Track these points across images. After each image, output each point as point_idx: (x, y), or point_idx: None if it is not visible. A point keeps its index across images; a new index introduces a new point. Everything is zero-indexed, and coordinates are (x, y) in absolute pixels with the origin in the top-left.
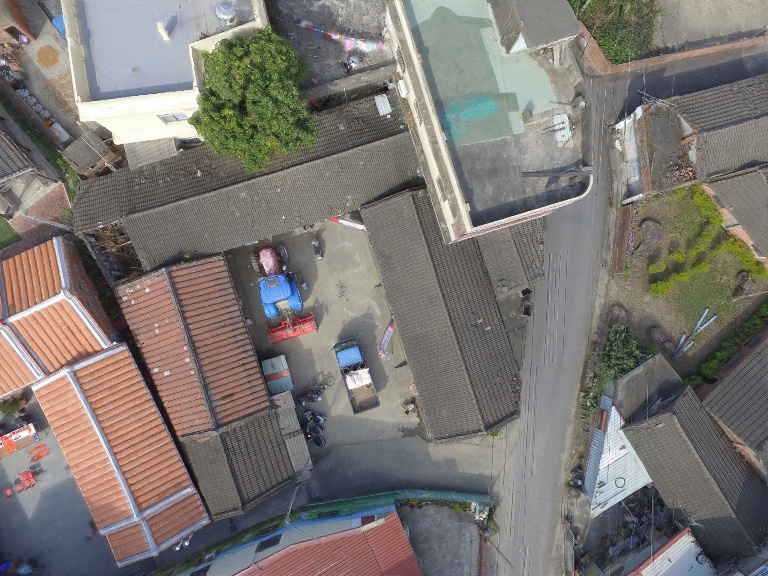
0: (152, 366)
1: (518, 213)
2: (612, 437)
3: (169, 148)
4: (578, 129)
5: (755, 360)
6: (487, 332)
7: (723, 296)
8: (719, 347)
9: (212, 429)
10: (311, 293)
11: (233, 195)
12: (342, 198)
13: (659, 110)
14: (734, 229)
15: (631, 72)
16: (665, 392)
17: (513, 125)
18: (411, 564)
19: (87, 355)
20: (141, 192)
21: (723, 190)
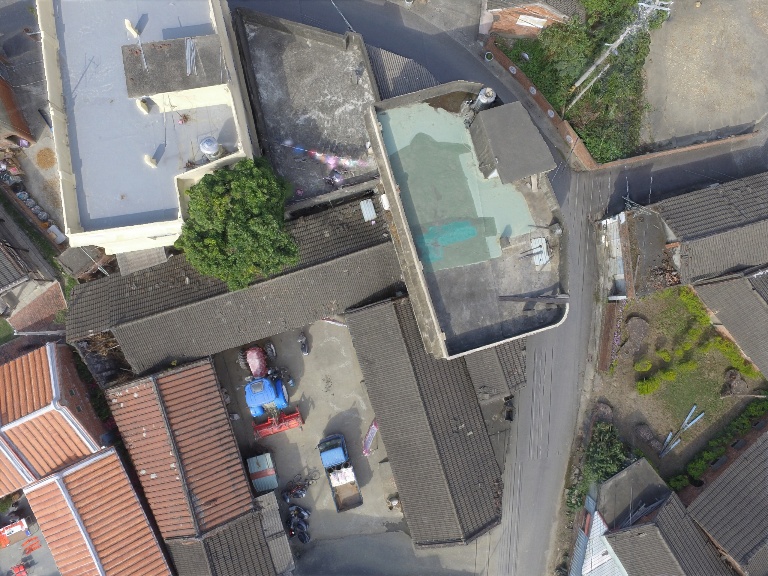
0: (139, 468)
1: (495, 337)
2: (595, 542)
3: (159, 256)
4: (556, 252)
5: (741, 465)
6: (469, 437)
7: (711, 393)
8: (706, 445)
9: (195, 536)
10: (298, 388)
11: (220, 304)
12: (327, 303)
13: None
14: (721, 327)
15: (618, 167)
16: (649, 497)
17: (491, 249)
18: None
19: (76, 459)
20: (131, 300)
21: (708, 294)
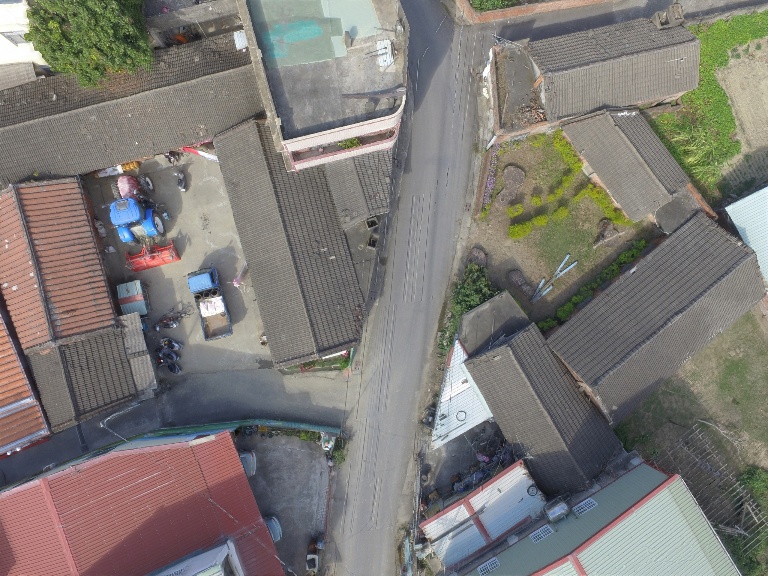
0: (2, 281)
1: None
2: (454, 370)
3: (28, 73)
4: (401, 55)
5: (603, 301)
6: (331, 261)
7: (585, 243)
8: (577, 292)
9: (49, 340)
10: (175, 225)
11: (84, 118)
12: (195, 127)
13: (514, 54)
14: (594, 176)
15: (501, 22)
16: (510, 329)
17: (336, 48)
18: (239, 481)
19: None
20: None
21: (575, 133)
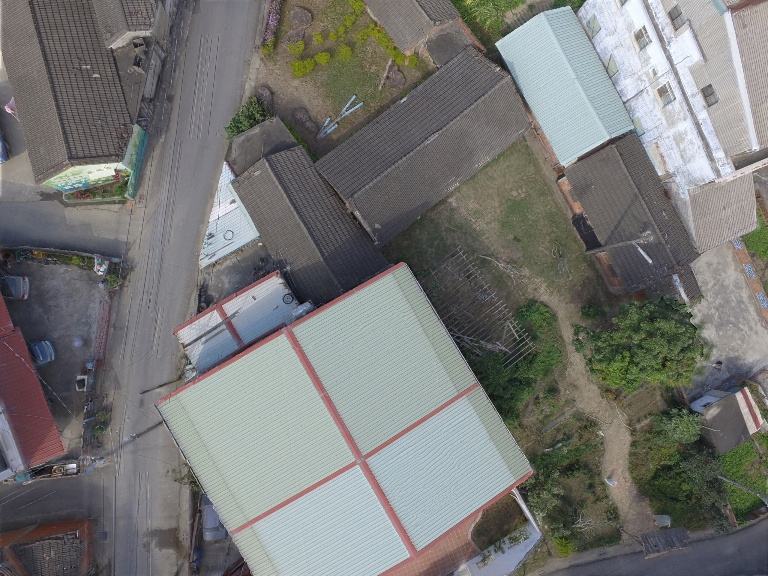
0: None
1: None
2: (222, 191)
3: None
4: None
5: (372, 128)
6: (94, 79)
7: (371, 84)
8: None
9: None
10: None
11: None
12: None
13: None
14: None
15: None
16: None
17: None
18: None
19: None
20: None
21: None
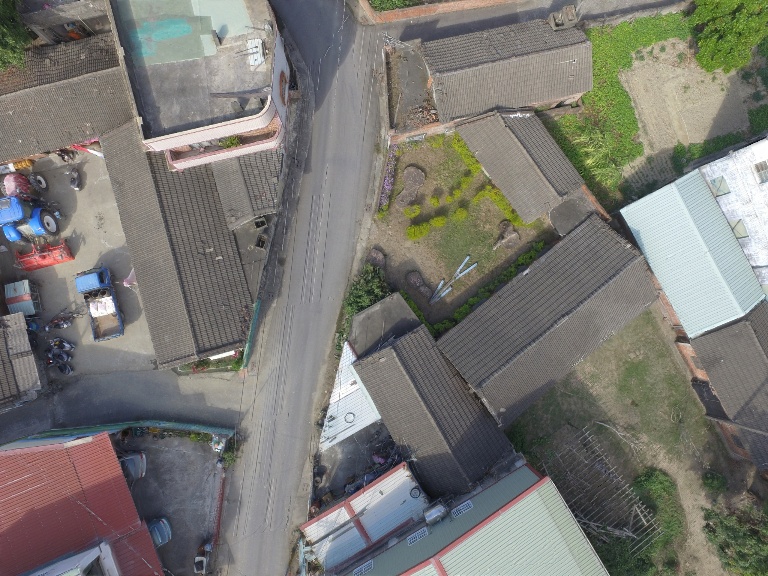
0: None
1: None
2: (343, 372)
3: None
4: None
5: (494, 303)
6: (217, 261)
7: (485, 244)
8: (476, 294)
9: None
10: (69, 224)
11: None
12: (81, 125)
13: (407, 54)
14: None
15: (404, 22)
16: (401, 330)
17: (205, 47)
18: (117, 483)
19: None
20: None
21: (468, 134)
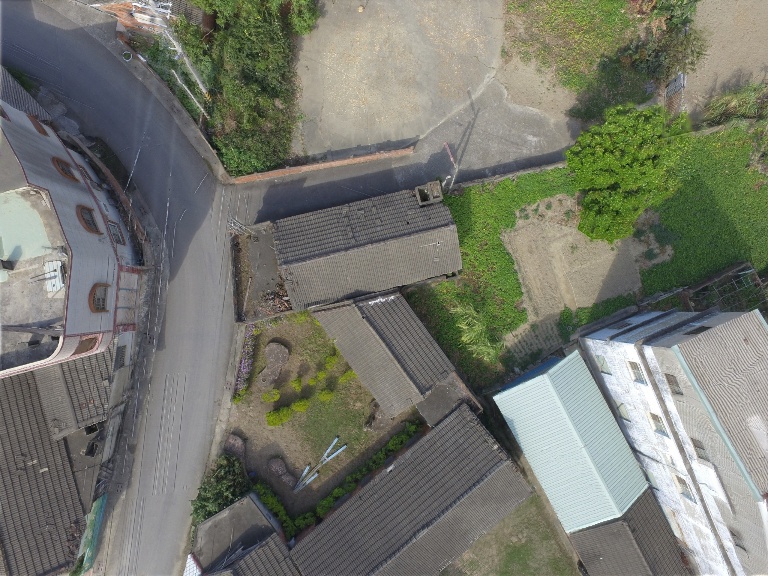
0: None
1: None
2: None
3: None
4: None
5: (355, 505)
6: (41, 475)
7: (355, 424)
8: (344, 481)
9: None
10: None
11: None
12: None
13: (259, 233)
14: None
15: (268, 181)
16: (251, 539)
17: None
18: None
19: None
20: None
21: (325, 321)
